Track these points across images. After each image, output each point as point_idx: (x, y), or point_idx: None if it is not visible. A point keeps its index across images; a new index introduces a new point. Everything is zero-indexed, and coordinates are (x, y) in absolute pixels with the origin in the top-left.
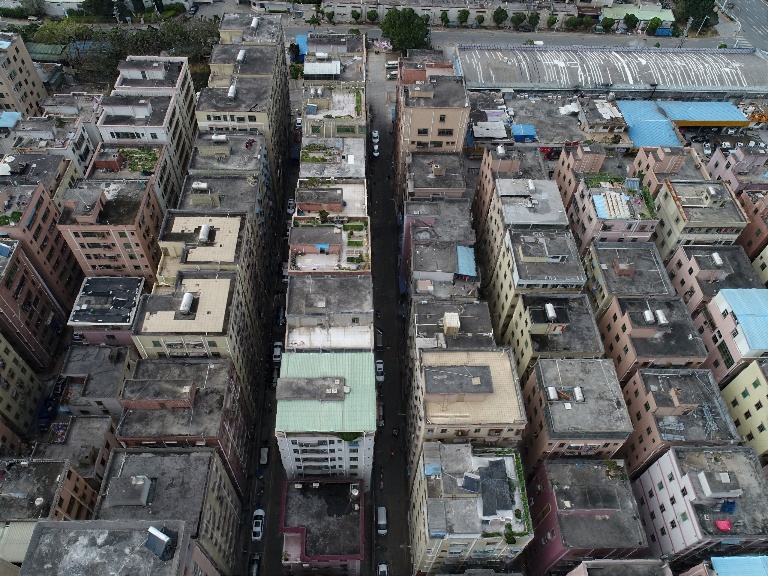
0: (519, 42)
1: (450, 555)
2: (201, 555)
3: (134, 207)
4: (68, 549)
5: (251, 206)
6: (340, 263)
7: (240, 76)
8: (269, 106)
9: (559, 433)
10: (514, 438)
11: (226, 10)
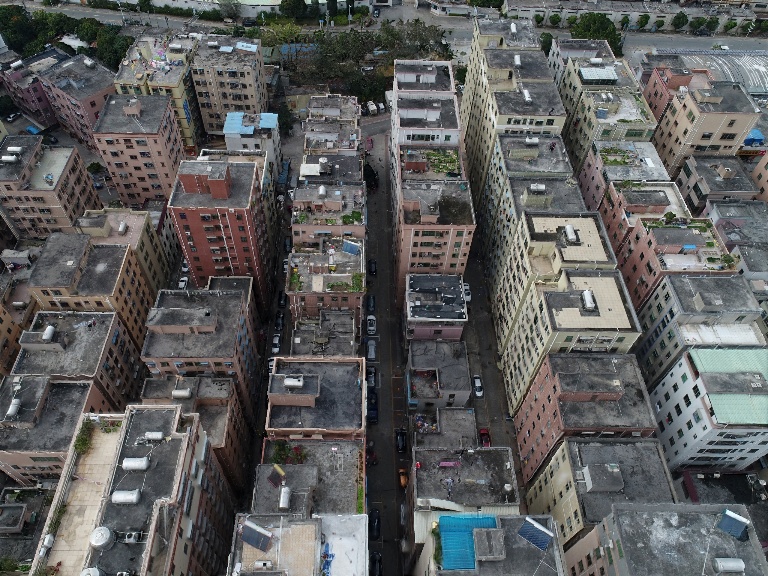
0: (699, 46)
1: None
2: None
3: (463, 207)
4: (650, 530)
5: (580, 207)
6: (702, 263)
7: (522, 80)
8: None
9: None
10: None
11: (407, 13)
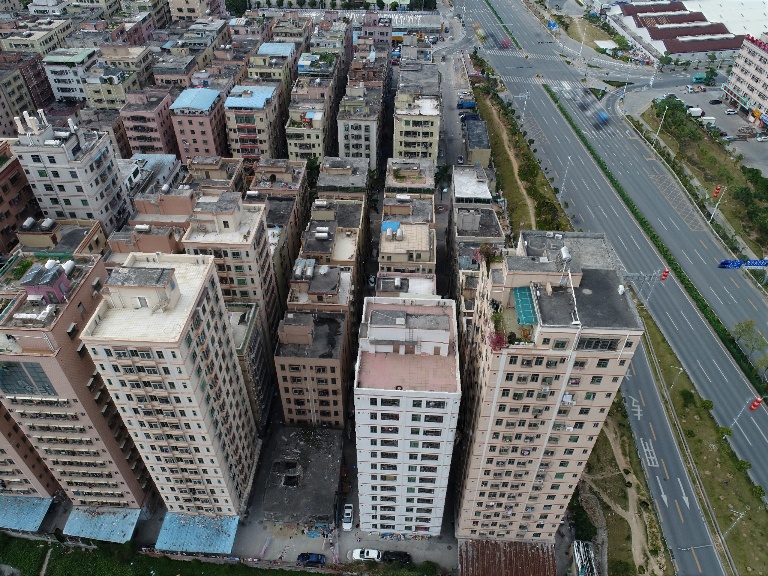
0: None
1: (100, 106)
2: None
3: None
4: None
5: None
6: None
7: None
8: None
9: (155, 69)
10: (138, 71)
11: None
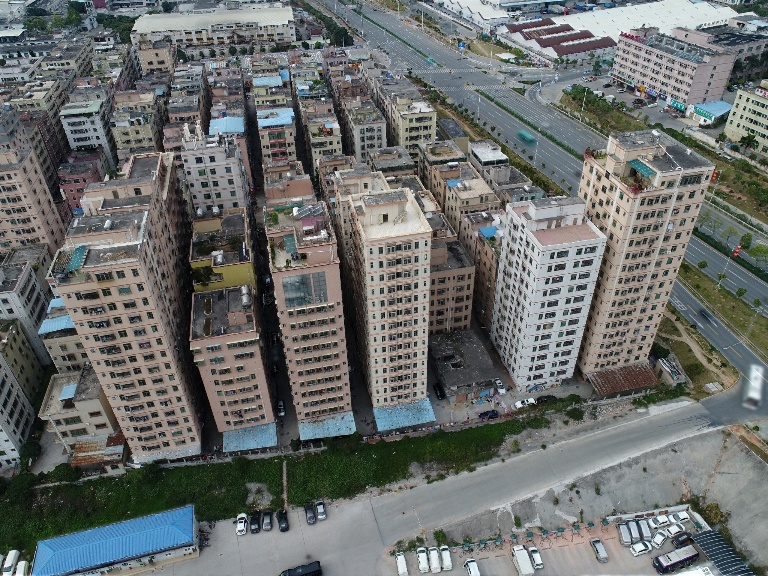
0: None
1: None
2: (27, 136)
3: None
4: None
5: None
6: None
7: None
8: (76, 59)
9: (170, 109)
10: (153, 113)
11: None
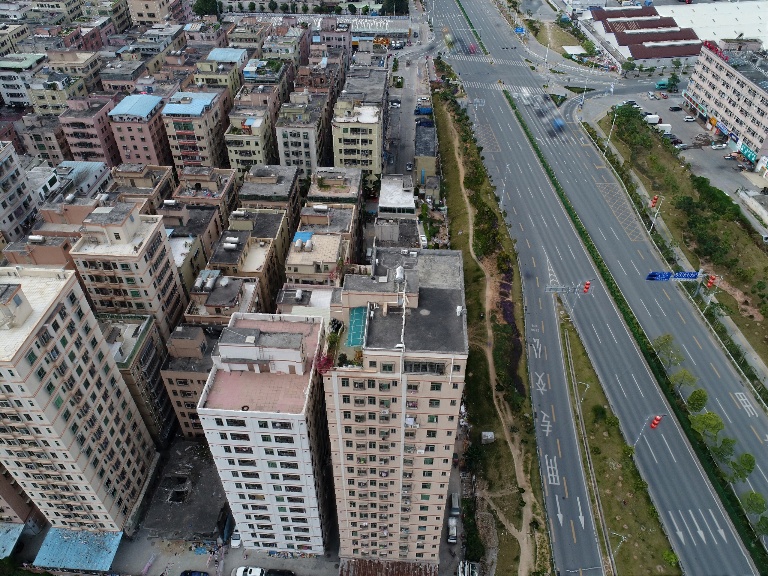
0: None
1: (46, 112)
2: None
3: None
4: None
5: None
6: None
7: None
8: (68, 2)
9: (102, 75)
10: (85, 77)
11: None
